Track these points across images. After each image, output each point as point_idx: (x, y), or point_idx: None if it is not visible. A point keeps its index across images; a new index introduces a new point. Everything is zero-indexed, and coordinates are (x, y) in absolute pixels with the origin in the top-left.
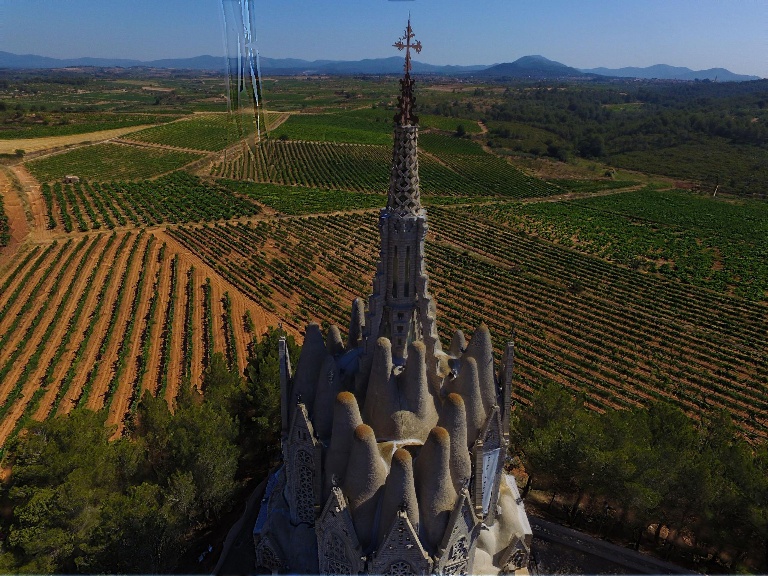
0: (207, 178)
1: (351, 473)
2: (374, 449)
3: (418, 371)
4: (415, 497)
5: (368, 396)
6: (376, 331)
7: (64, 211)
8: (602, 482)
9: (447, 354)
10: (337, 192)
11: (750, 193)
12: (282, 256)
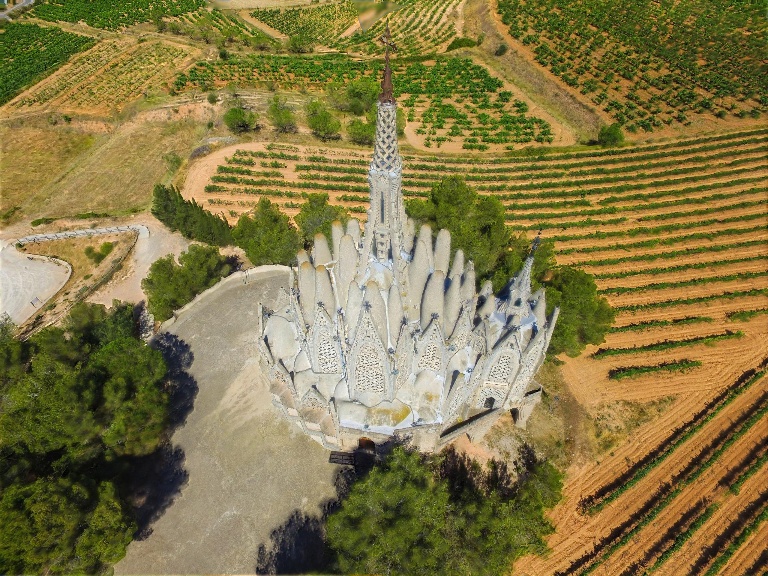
0: None
1: None
2: (315, 247)
3: None
4: None
5: None
6: None
7: None
8: None
9: None
10: None
11: None
12: None
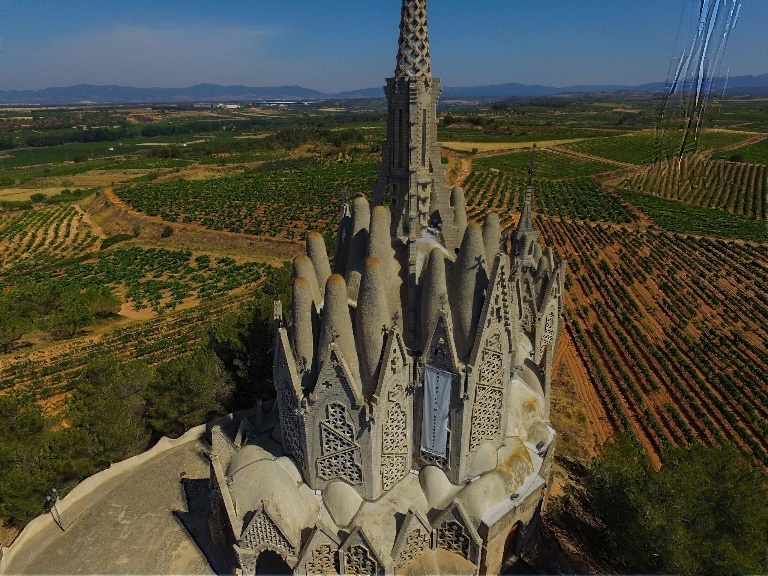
0: (610, 187)
1: None
2: None
3: (369, 233)
4: (308, 332)
5: None
6: (379, 201)
7: (468, 190)
8: (657, 570)
9: None
10: (765, 223)
11: None
12: (617, 262)
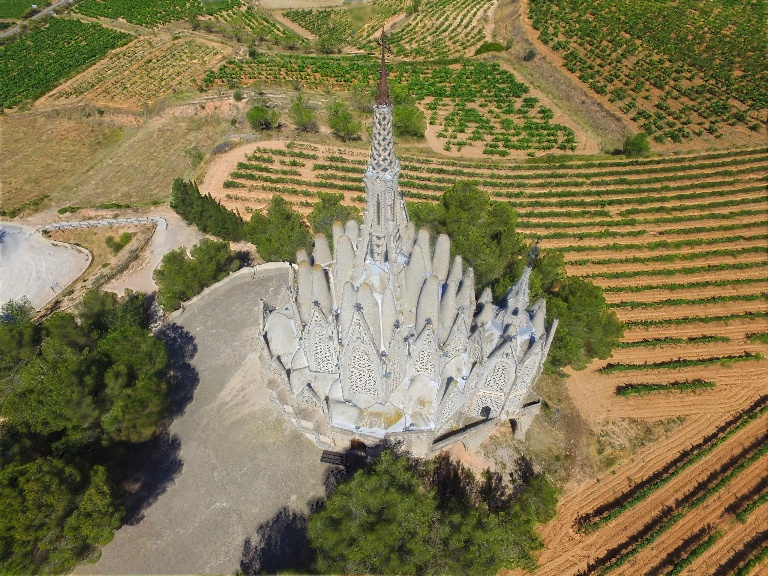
0: None
1: None
2: None
3: None
4: None
5: None
6: None
7: None
8: None
9: None
10: None
11: None
12: None
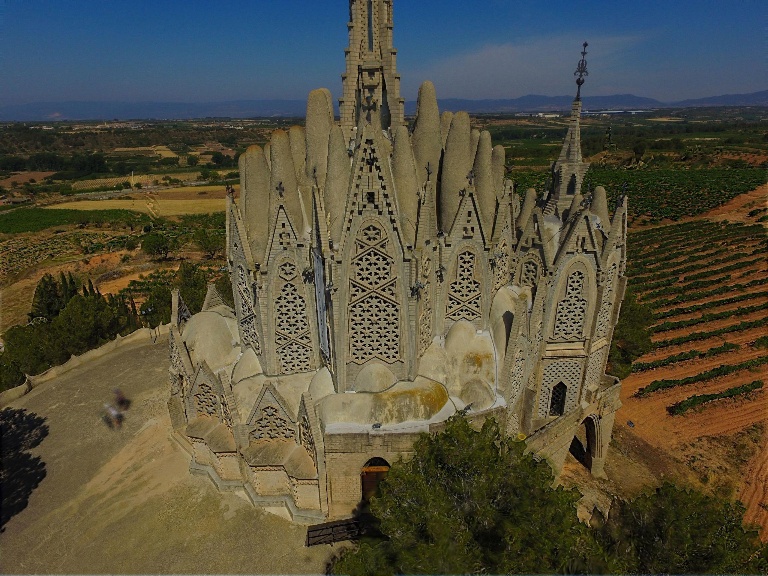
0: None
1: None
2: None
3: None
4: None
5: None
6: None
7: None
8: None
9: (390, 155)
10: None
11: None
12: None
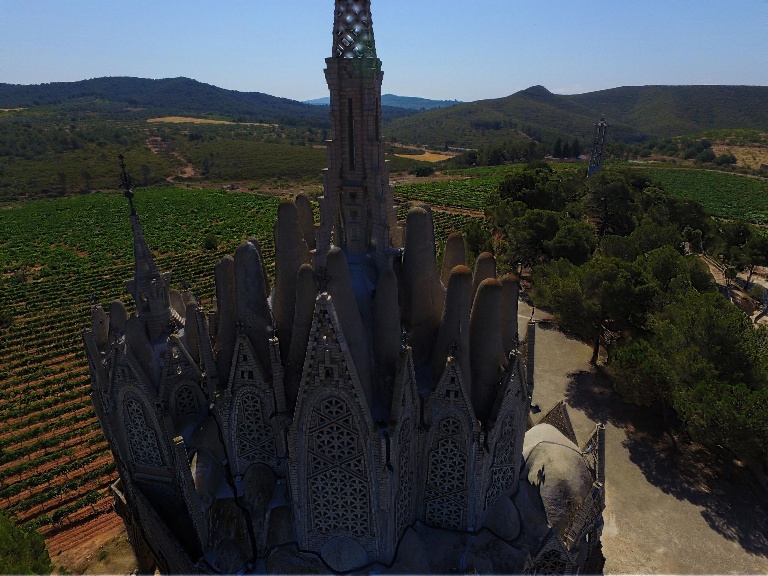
0: None
1: (498, 336)
2: None
3: None
4: None
5: (420, 288)
6: None
7: None
8: None
9: None
10: None
11: (22, 195)
12: None
